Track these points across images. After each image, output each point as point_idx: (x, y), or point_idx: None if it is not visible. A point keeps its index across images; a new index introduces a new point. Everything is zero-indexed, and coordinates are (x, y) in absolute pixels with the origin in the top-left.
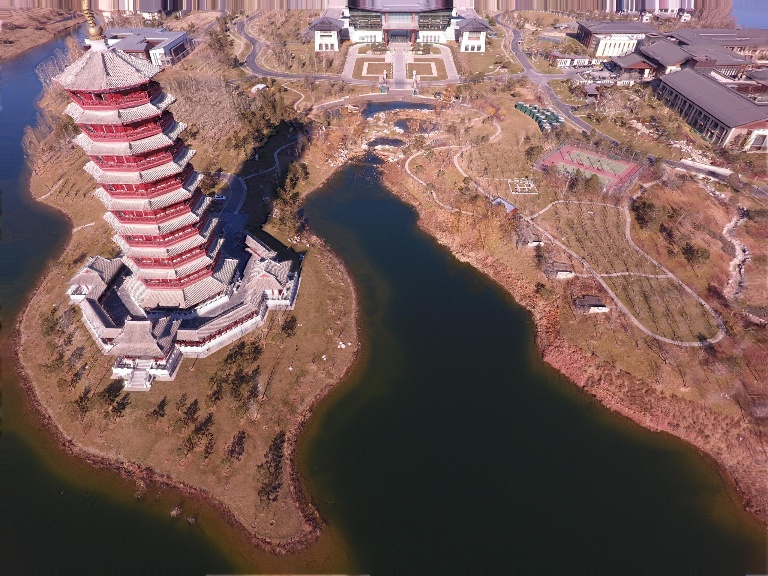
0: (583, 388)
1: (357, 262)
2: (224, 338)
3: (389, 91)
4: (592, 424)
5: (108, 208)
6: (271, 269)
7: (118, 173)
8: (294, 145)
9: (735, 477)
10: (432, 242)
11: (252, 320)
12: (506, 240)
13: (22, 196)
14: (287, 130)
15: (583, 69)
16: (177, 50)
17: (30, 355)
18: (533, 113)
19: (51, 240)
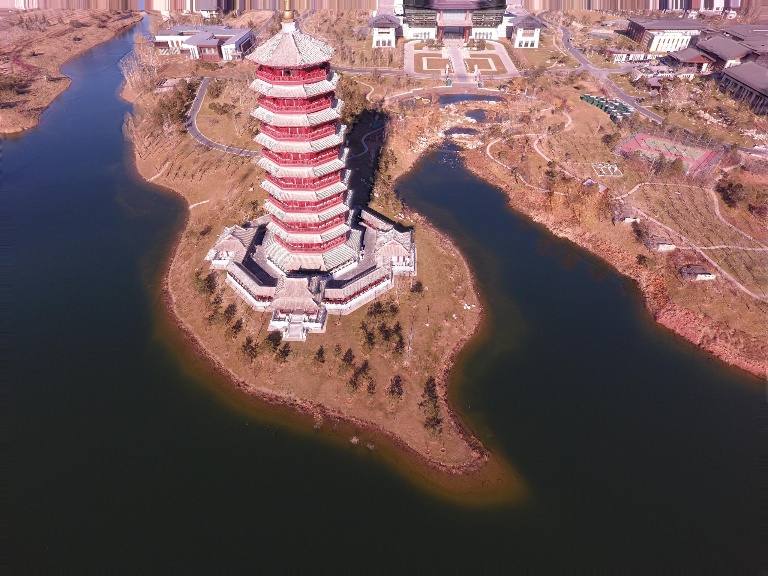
0: (699, 345)
1: (460, 237)
2: (362, 298)
3: (454, 84)
4: (712, 377)
5: (277, 175)
6: (397, 238)
7: (290, 143)
8: (377, 133)
9: None
10: (526, 220)
11: (384, 283)
12: (601, 217)
13: (132, 177)
14: (368, 119)
15: (639, 64)
16: (245, 46)
17: (185, 312)
18: (601, 104)
19: (171, 216)
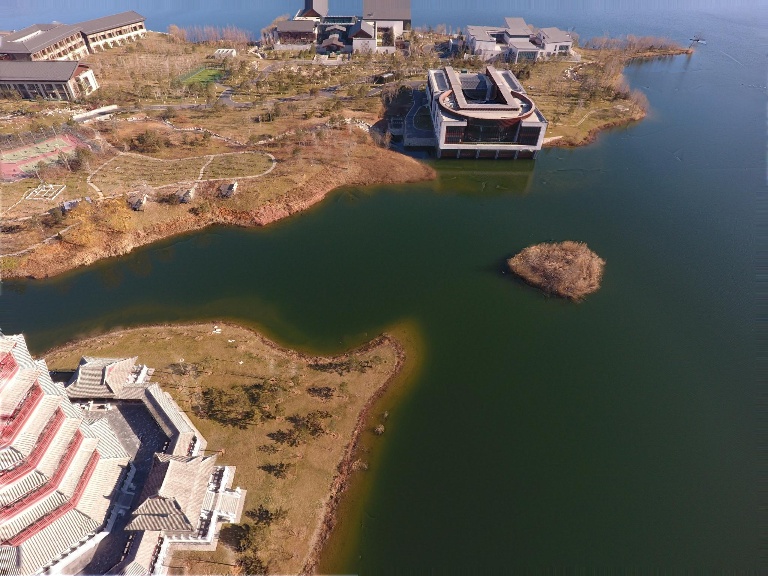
0: (291, 214)
1: (79, 331)
2: None
3: None
4: None
5: None
6: None
7: None
8: None
9: (352, 183)
10: (80, 271)
11: None
12: (125, 215)
13: None
14: None
15: None
16: None
17: None
18: None
19: None
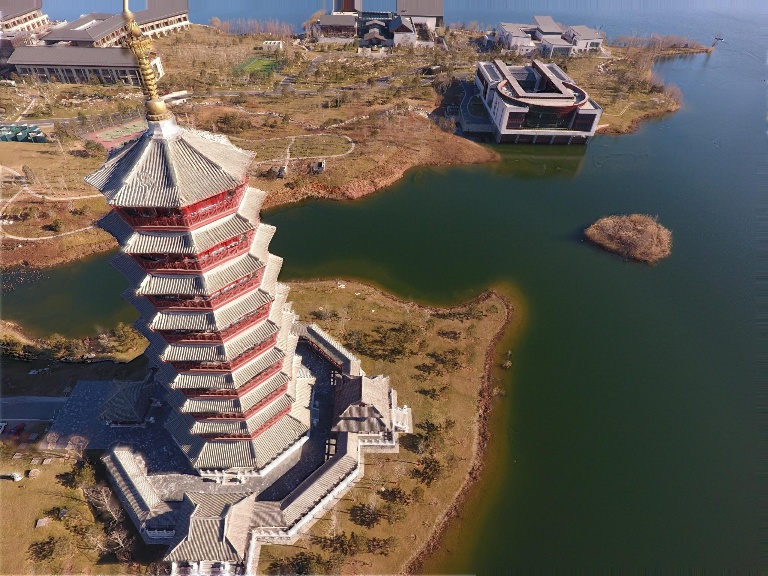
0: (376, 190)
1: None
2: None
3: None
4: None
5: (281, 326)
6: None
7: None
8: None
9: (425, 163)
10: None
11: None
12: None
13: None
14: None
15: None
16: None
17: None
18: None
19: None
